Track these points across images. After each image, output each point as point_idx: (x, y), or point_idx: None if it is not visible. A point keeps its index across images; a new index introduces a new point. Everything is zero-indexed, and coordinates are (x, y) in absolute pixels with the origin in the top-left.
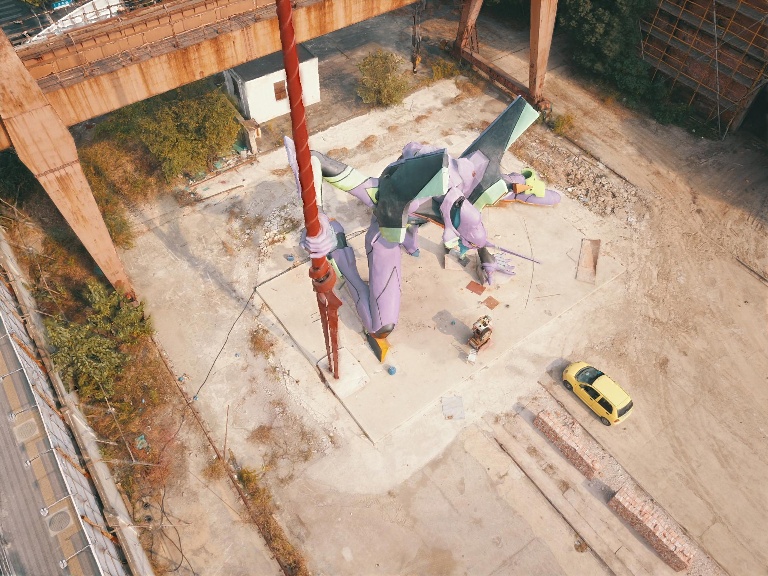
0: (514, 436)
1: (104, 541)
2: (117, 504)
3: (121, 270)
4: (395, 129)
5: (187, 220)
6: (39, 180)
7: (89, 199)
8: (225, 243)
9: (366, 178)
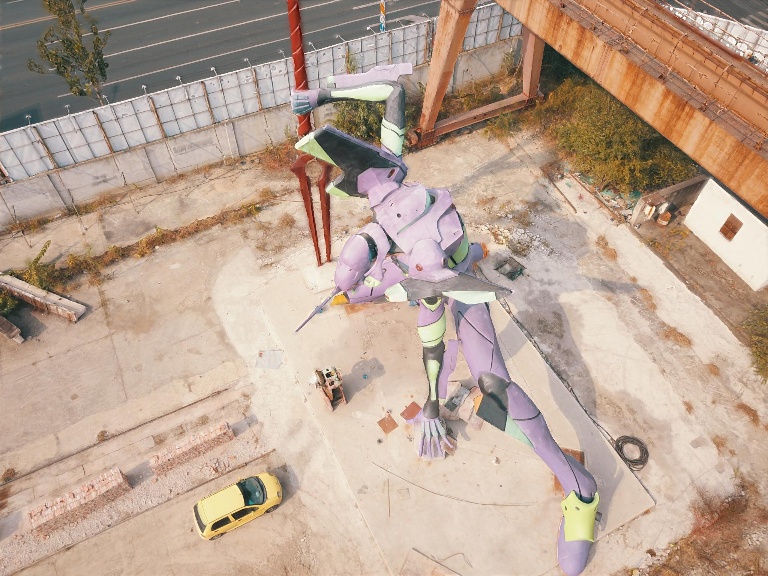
0: (224, 408)
1: (204, 111)
2: (247, 136)
3: (430, 111)
4: (711, 371)
5: (525, 173)
6: None
7: (448, 44)
8: (493, 199)
9: (393, 150)
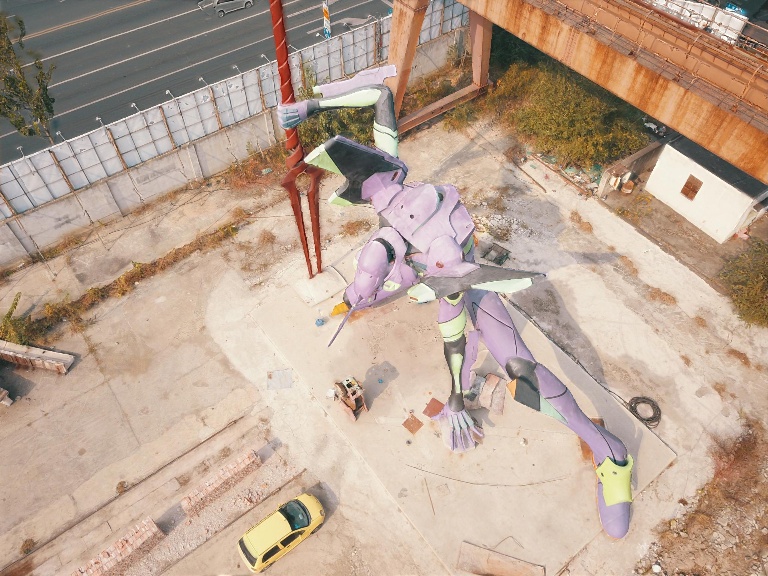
0: (244, 436)
1: (164, 137)
2: (210, 157)
3: None
4: (699, 324)
5: (490, 161)
6: (394, 1)
7: (405, 43)
8: (465, 189)
9: (390, 153)
